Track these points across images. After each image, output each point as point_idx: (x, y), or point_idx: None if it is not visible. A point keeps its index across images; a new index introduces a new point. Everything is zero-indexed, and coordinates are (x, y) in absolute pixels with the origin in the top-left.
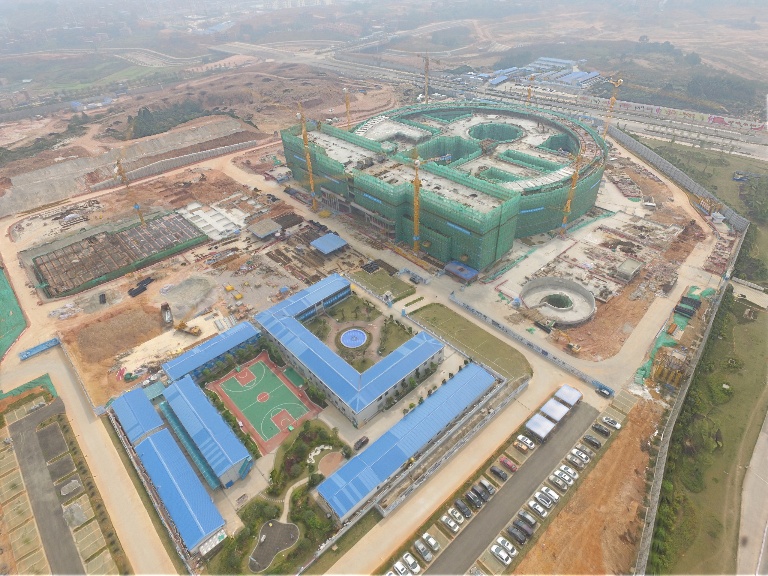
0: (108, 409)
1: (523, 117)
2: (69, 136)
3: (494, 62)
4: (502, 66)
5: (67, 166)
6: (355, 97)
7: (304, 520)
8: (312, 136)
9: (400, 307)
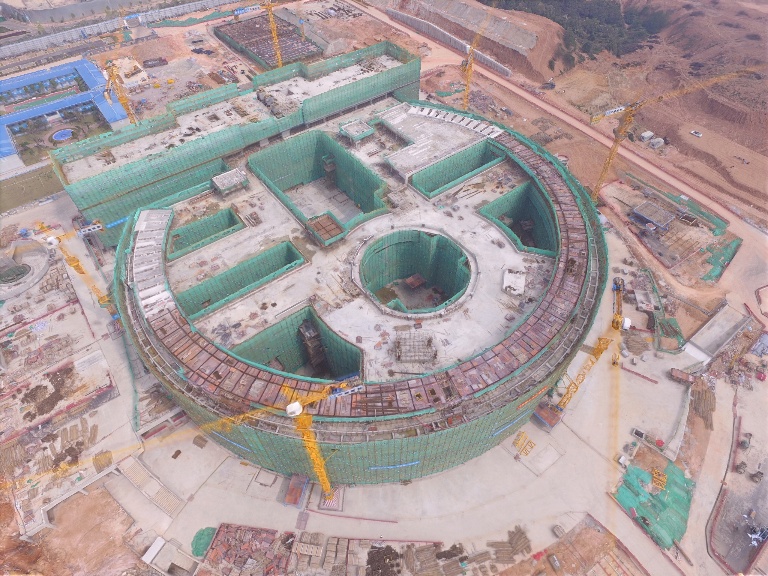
0: None
1: None
2: None
3: None
4: None
5: None
6: None
7: None
8: None
9: None
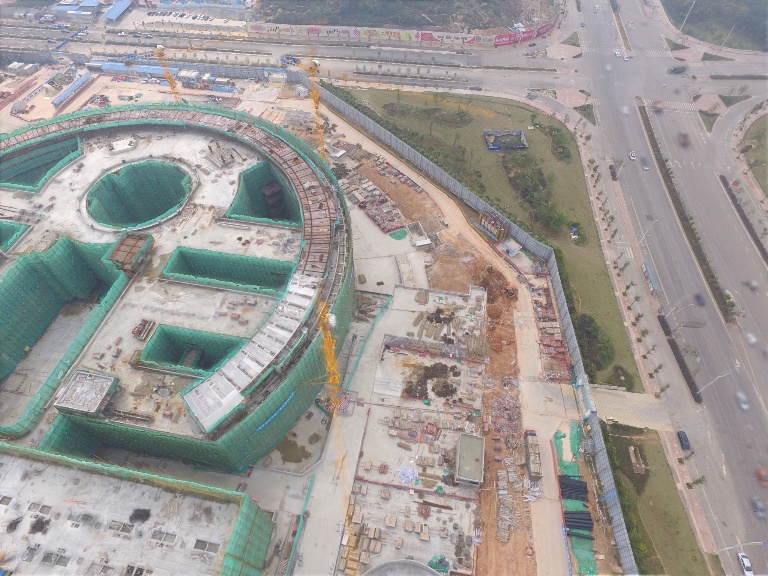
0: None
1: (179, 130)
2: None
3: None
4: None
5: None
6: None
7: None
8: None
9: None
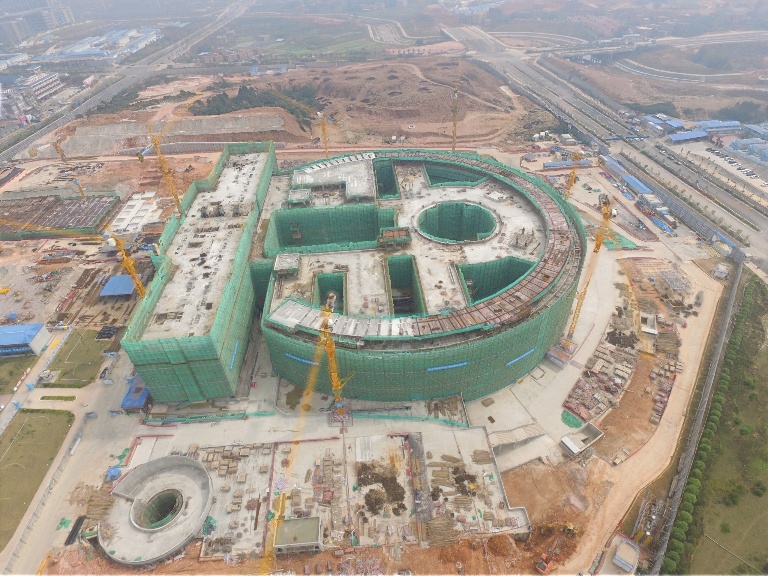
0: None
1: (535, 210)
2: (171, 100)
3: (725, 106)
4: (732, 114)
5: (119, 128)
6: (464, 116)
7: None
8: (255, 158)
9: (36, 396)
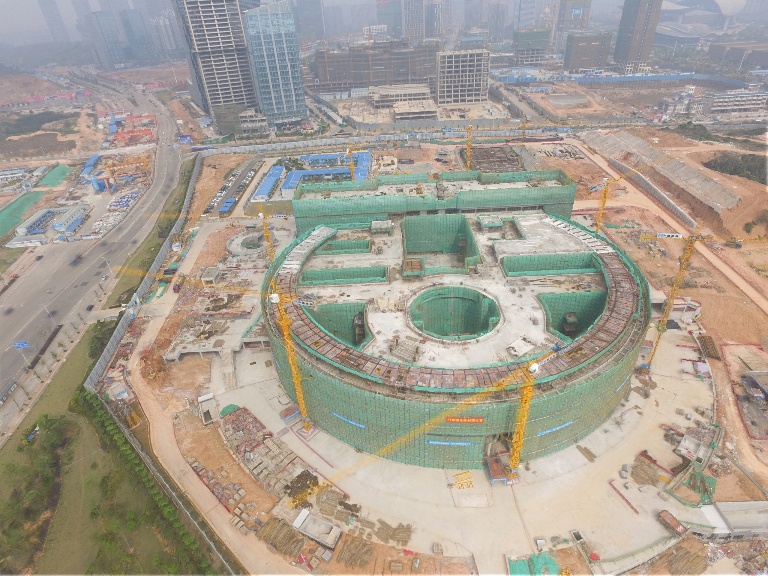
0: None
1: None
2: (742, 145)
3: None
4: None
5: (637, 142)
6: None
7: None
8: None
9: None
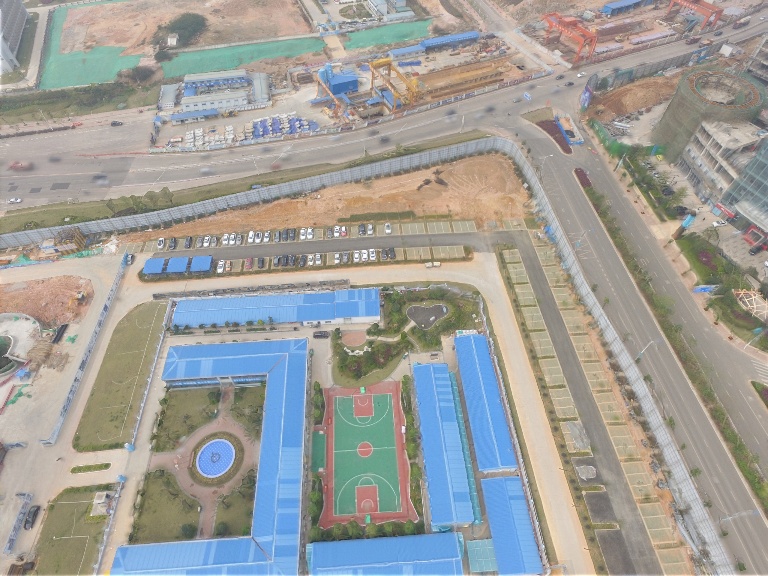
0: (547, 569)
1: None
2: None
3: None
4: None
5: None
6: None
7: (400, 311)
8: None
9: (117, 469)
